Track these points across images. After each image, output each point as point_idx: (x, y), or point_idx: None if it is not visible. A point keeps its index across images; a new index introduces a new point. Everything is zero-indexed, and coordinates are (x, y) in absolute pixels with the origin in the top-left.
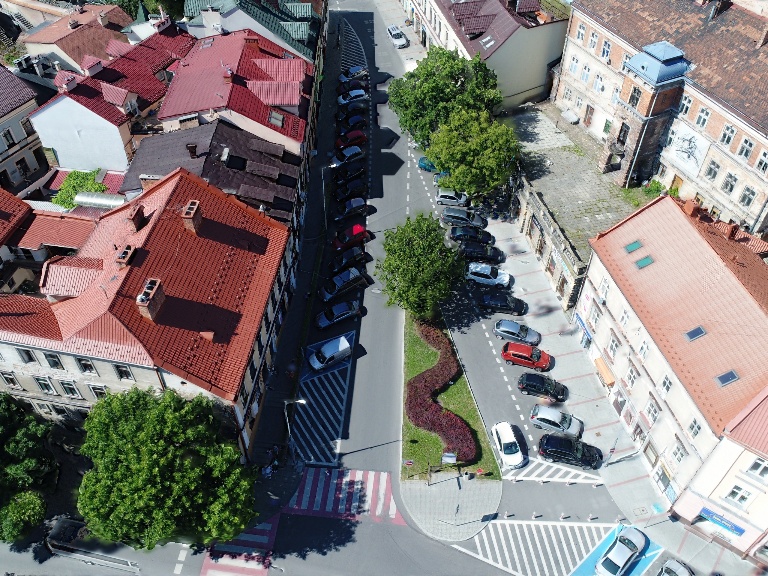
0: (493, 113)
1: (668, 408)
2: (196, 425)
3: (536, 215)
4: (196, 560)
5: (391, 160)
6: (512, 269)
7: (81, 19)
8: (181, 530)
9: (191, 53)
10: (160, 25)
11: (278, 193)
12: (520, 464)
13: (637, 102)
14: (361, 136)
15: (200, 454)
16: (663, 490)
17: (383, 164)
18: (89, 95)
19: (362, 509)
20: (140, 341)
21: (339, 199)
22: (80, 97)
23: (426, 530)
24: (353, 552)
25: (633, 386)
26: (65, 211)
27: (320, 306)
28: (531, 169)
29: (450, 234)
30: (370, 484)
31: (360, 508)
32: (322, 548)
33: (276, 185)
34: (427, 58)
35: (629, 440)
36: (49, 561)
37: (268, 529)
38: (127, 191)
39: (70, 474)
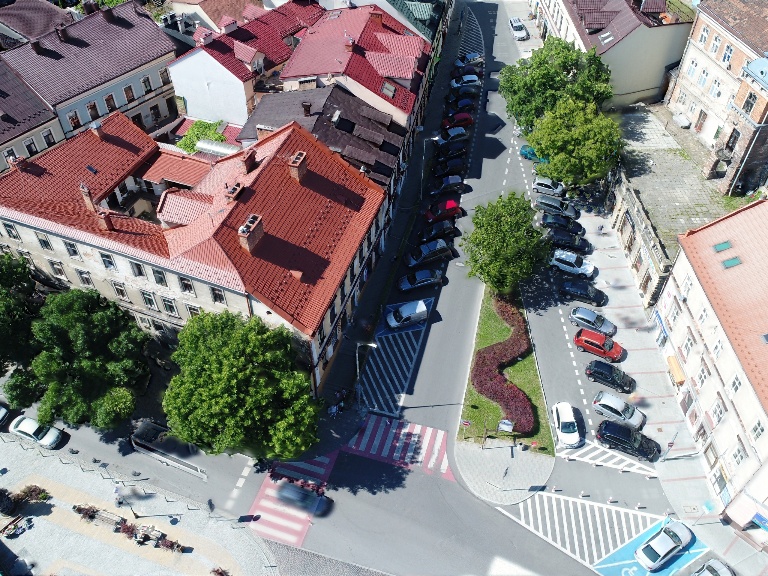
0: (602, 109)
1: (734, 408)
2: (275, 350)
3: (630, 211)
4: (257, 478)
5: (494, 145)
6: (598, 261)
7: None
8: (248, 441)
9: (319, 22)
10: None
11: (380, 158)
12: (575, 444)
13: (751, 108)
14: (468, 119)
15: (275, 376)
16: (718, 492)
17: (485, 147)
18: (222, 51)
19: (416, 460)
20: (236, 268)
21: (437, 175)
22: (214, 51)
23: (473, 489)
24: (401, 496)
25: (702, 385)
26: None
27: (404, 270)
28: (632, 166)
29: (541, 220)
30: (427, 439)
31: (414, 458)
32: (373, 488)
33: (379, 151)
34: (543, 48)
35: (691, 440)
36: (131, 455)
37: (326, 462)
38: (243, 139)
39: (159, 385)
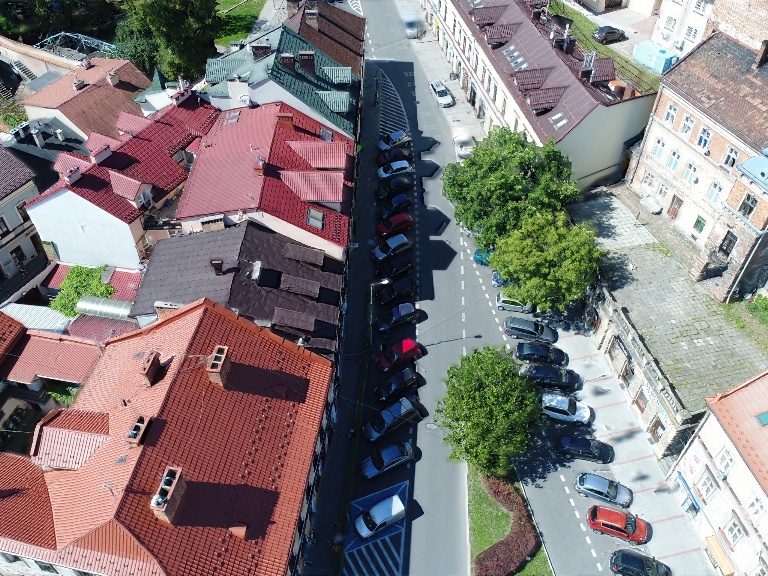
0: None
1: None
2: None
3: (622, 338)
4: None
5: (441, 250)
6: (591, 399)
7: (88, 77)
8: None
9: (214, 129)
10: (179, 97)
11: (318, 314)
12: None
13: (750, 212)
14: (407, 221)
15: None
16: None
17: (432, 255)
18: (95, 187)
19: None
20: (154, 556)
21: (384, 302)
22: (84, 190)
23: None
24: None
25: None
26: (65, 323)
27: (366, 447)
28: (611, 275)
29: (516, 352)
30: None
31: None
32: None
33: (316, 303)
34: (488, 139)
35: None
36: None
37: None
38: (139, 315)
39: None
